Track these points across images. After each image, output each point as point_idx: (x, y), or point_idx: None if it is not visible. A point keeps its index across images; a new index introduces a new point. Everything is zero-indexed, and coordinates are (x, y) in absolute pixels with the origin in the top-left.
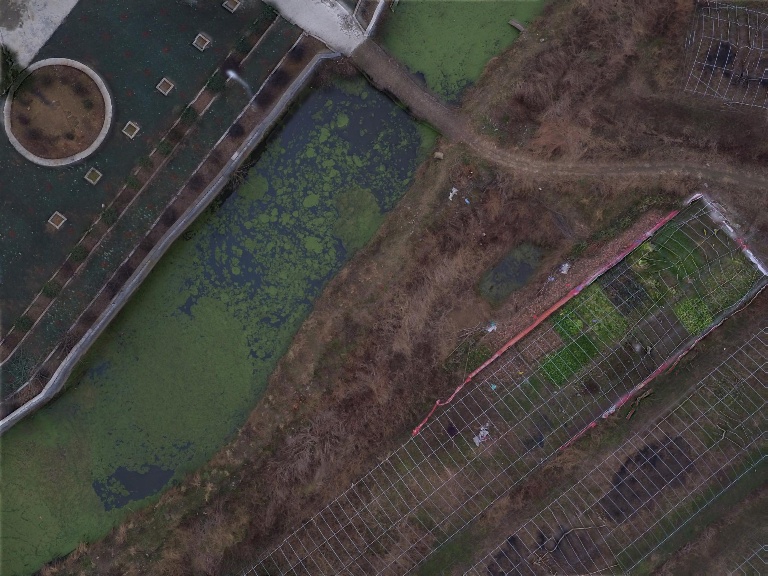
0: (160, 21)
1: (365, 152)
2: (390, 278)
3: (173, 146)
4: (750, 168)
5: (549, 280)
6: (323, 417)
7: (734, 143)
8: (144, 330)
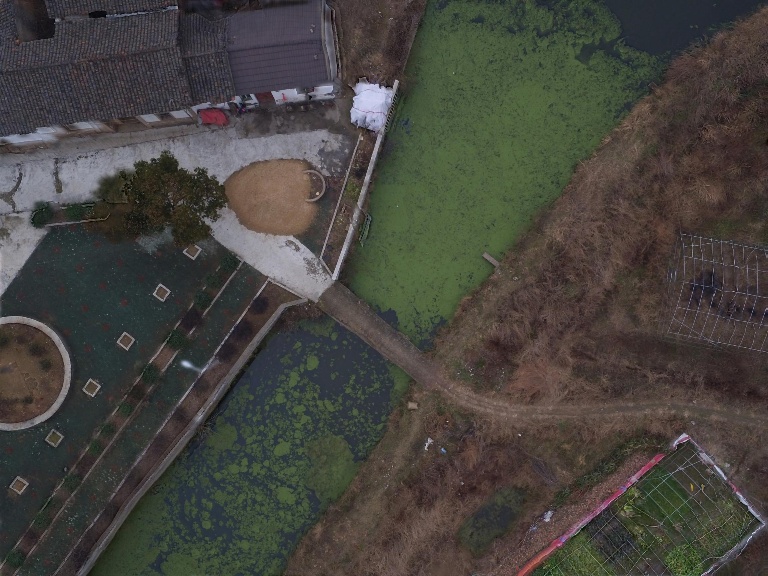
0: (118, 272)
1: (337, 396)
2: (365, 536)
3: (136, 404)
4: (739, 404)
5: (531, 529)
6: None
7: (721, 379)
8: None
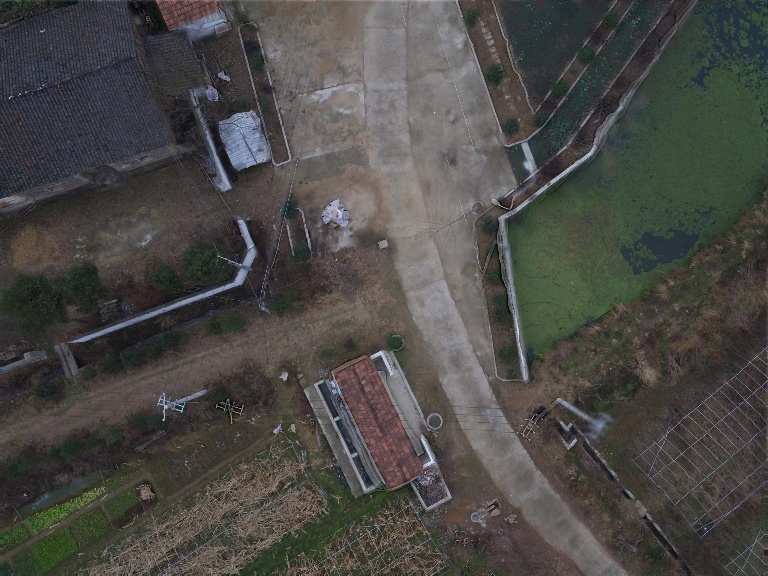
0: None
1: None
2: None
3: None
4: None
5: None
6: None
7: None
8: (660, 101)
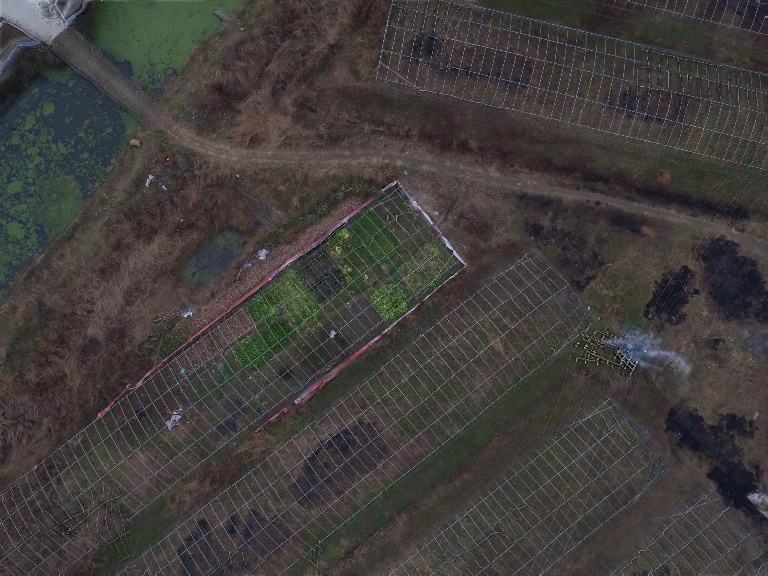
0: None
1: (70, 139)
2: (83, 263)
3: None
4: (449, 156)
5: (246, 266)
6: (17, 401)
7: (432, 131)
8: None
